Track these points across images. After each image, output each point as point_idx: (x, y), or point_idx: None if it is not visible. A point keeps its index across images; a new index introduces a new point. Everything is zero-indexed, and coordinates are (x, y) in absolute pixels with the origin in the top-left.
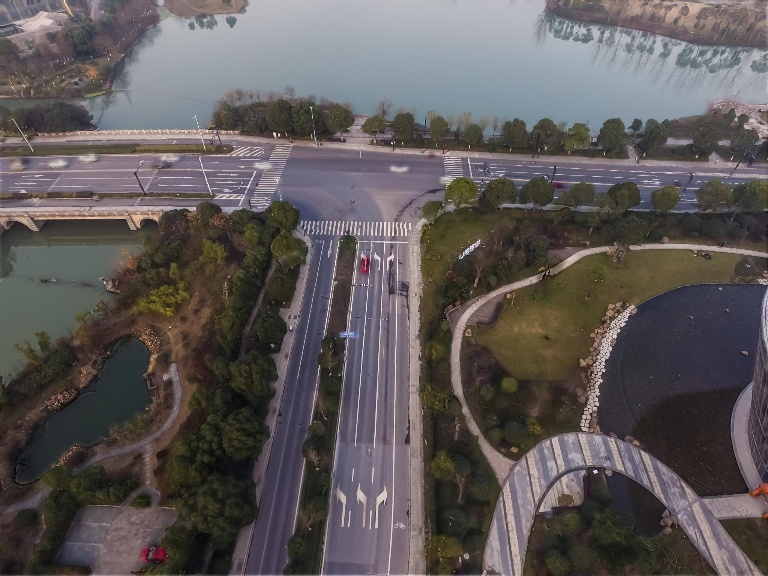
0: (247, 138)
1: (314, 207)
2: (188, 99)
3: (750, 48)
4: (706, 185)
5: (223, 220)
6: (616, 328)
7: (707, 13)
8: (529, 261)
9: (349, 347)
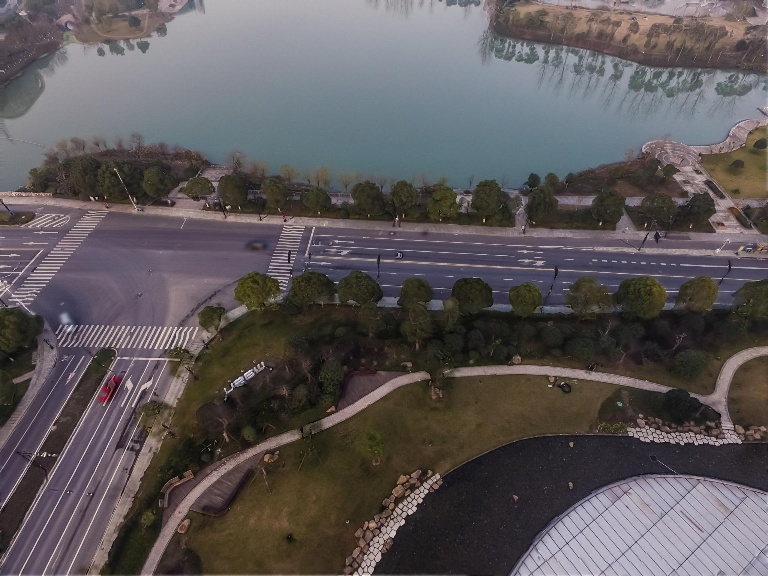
0: (58, 202)
1: (87, 303)
2: (34, 146)
3: (711, 69)
4: (576, 283)
5: None
6: (400, 517)
7: (659, 30)
8: (312, 400)
9: (15, 546)
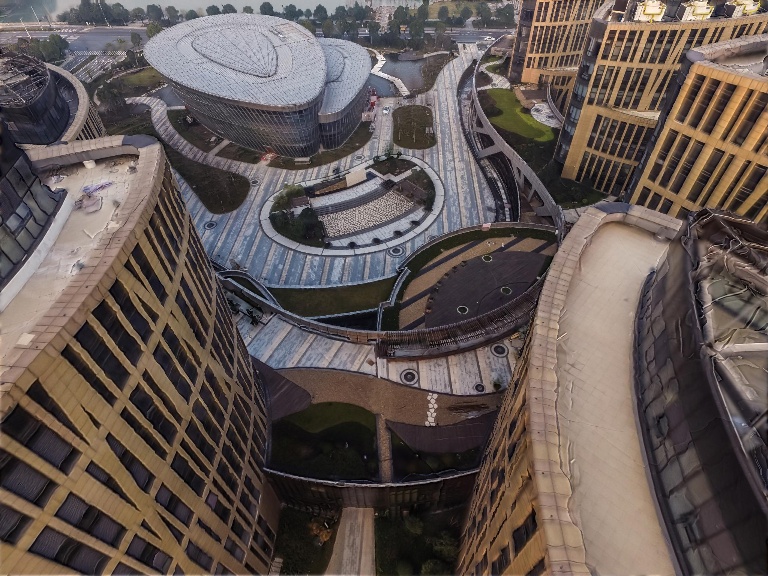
0: (71, 26)
1: None
2: None
3: None
4: None
5: (27, 45)
6: None
7: None
8: None
9: None
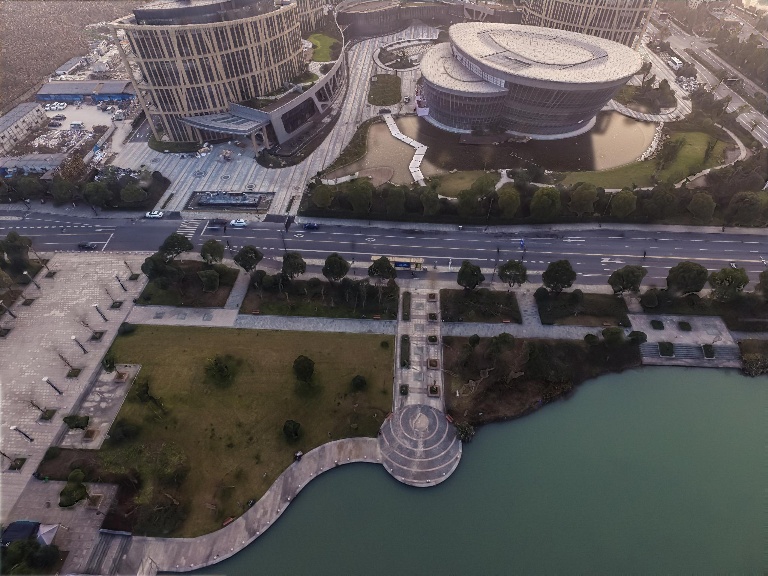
0: None
1: None
2: None
3: None
4: None
5: None
6: (649, 152)
7: None
8: None
9: None
